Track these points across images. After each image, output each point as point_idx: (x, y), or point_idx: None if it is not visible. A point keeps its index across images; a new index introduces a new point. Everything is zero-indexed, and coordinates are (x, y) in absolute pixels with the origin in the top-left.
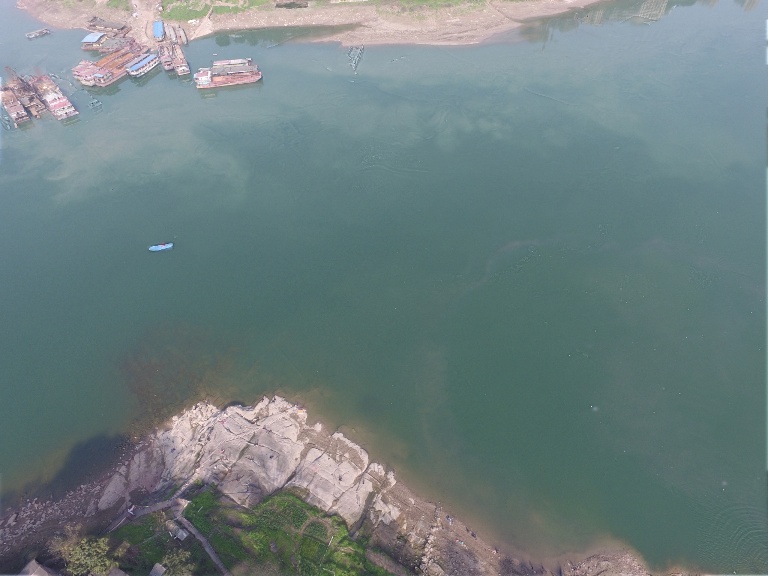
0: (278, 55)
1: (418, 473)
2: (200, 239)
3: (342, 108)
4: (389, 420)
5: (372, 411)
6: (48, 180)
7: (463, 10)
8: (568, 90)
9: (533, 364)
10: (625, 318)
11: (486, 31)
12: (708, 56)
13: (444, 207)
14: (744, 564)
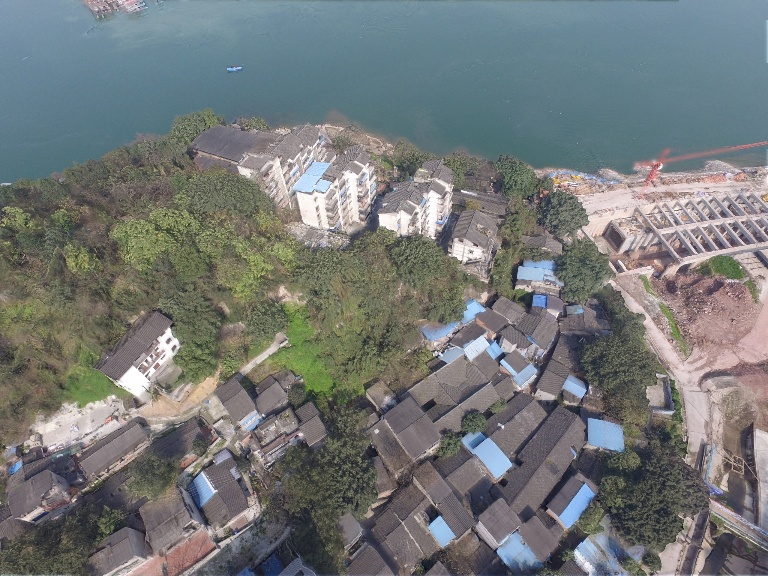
0: None
1: None
2: (259, 66)
3: None
4: (393, 130)
5: (383, 127)
6: (142, 42)
7: None
8: None
9: (477, 106)
10: (533, 87)
11: None
12: None
13: (420, 45)
14: (583, 165)
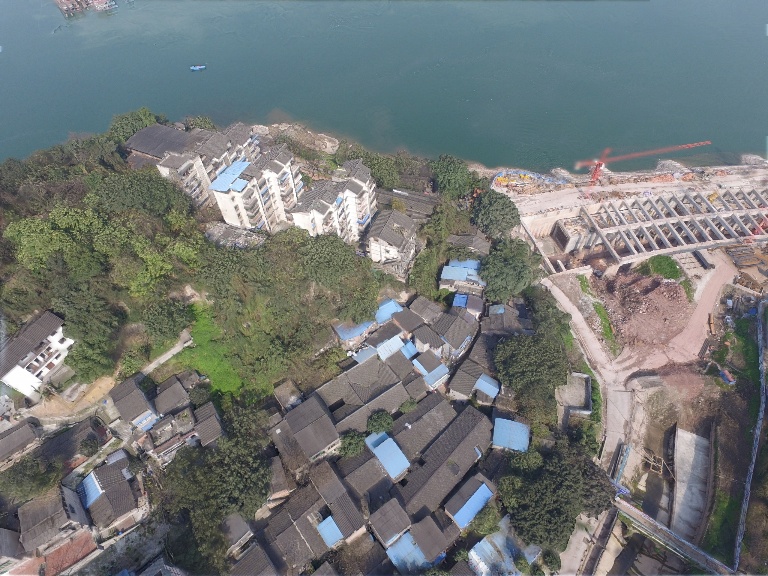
0: None
1: (367, 146)
2: (223, 65)
3: None
4: (350, 129)
5: (340, 126)
6: (108, 40)
7: None
8: None
9: (436, 106)
10: (494, 86)
11: None
12: None
13: (386, 44)
14: (536, 165)
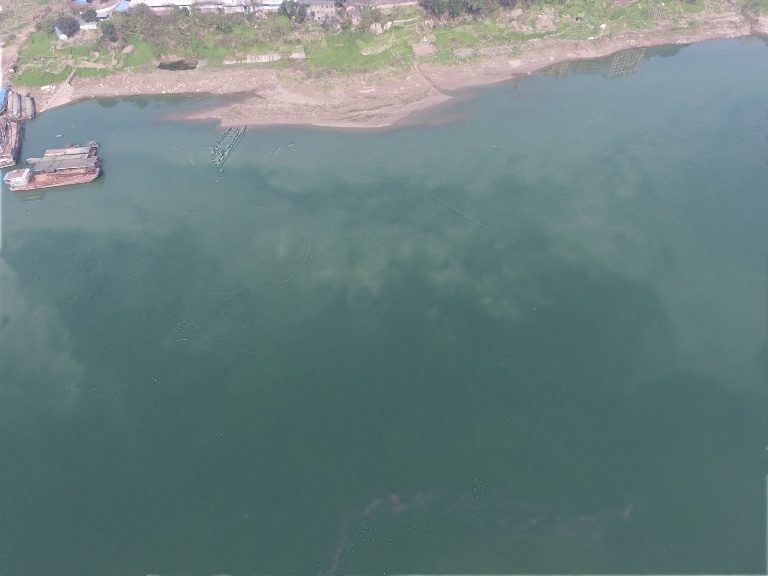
0: (136, 139)
1: None
2: None
3: (178, 233)
4: None
5: None
6: None
7: (381, 77)
8: (488, 203)
9: None
10: None
11: (403, 107)
12: (675, 153)
13: (260, 426)
14: None
